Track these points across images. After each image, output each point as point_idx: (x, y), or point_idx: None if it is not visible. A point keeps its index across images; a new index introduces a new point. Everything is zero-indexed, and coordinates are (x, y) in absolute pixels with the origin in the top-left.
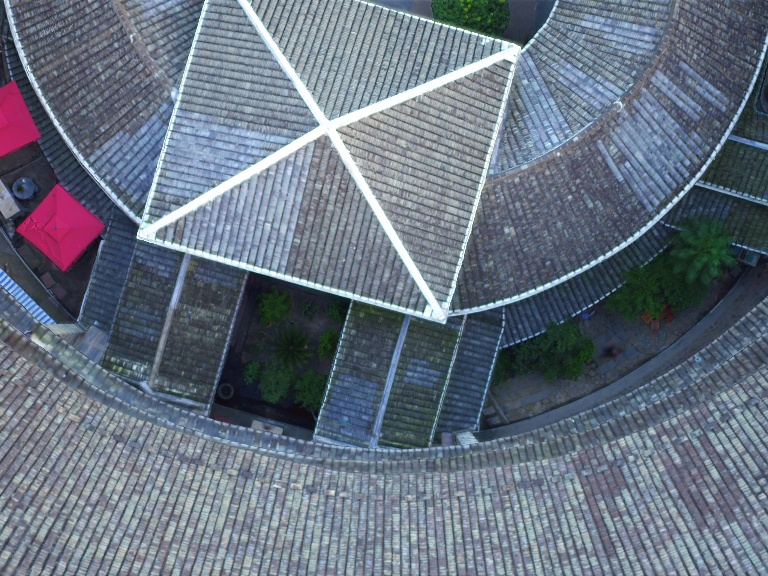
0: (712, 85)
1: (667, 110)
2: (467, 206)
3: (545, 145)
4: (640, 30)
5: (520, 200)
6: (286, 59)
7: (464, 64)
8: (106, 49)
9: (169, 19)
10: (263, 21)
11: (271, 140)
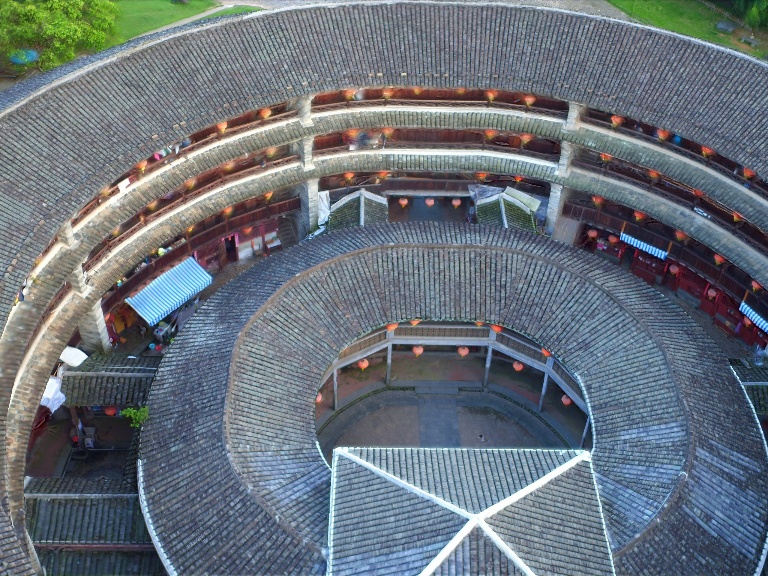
0: (740, 454)
1: (720, 476)
2: (608, 574)
3: (644, 518)
4: (668, 427)
5: (646, 567)
6: (419, 488)
7: (555, 467)
8: (253, 537)
9: (301, 504)
10: (388, 472)
11: (429, 549)
